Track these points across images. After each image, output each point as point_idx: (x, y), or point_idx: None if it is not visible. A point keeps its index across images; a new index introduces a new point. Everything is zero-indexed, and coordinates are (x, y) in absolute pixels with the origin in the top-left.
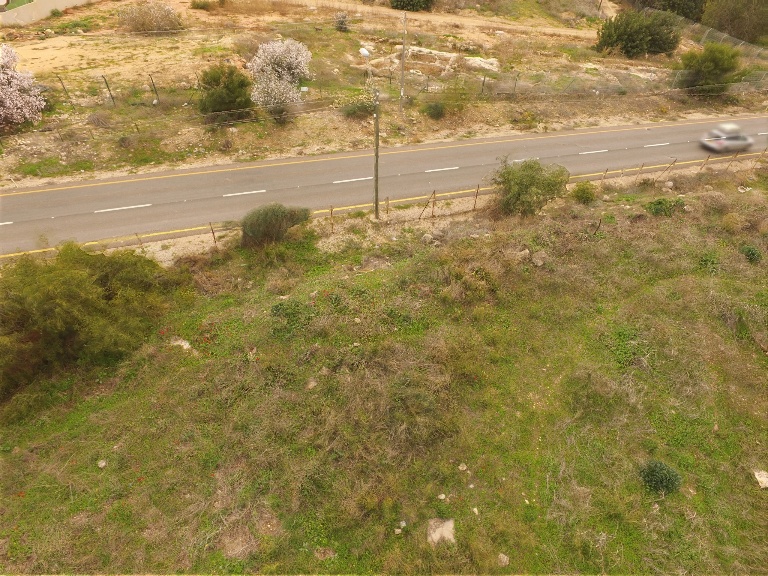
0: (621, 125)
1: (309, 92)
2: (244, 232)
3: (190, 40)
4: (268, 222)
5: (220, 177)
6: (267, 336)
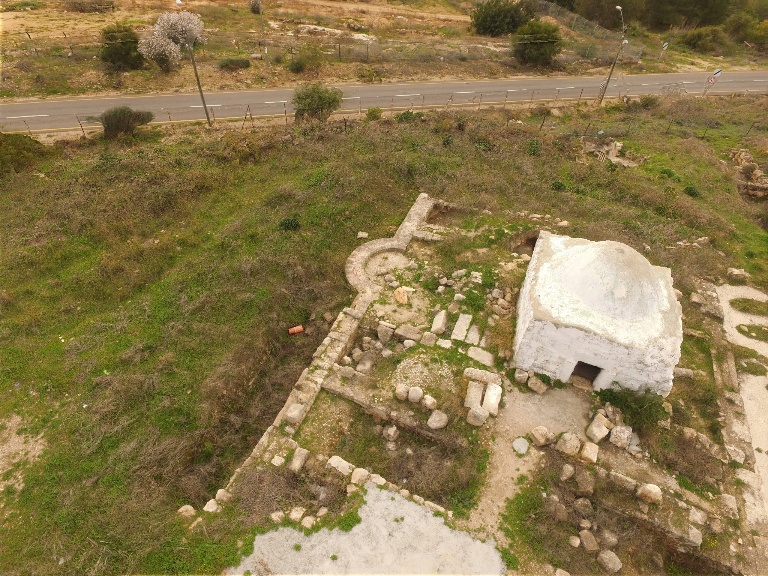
0: (447, 80)
1: (199, 52)
2: (105, 127)
3: (117, 16)
4: (118, 117)
5: (106, 102)
6: (92, 169)
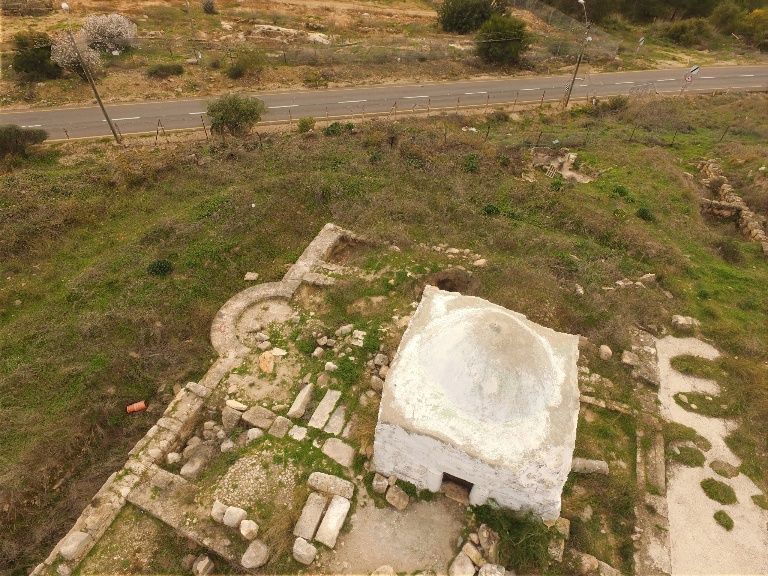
0: (401, 83)
1: (131, 58)
2: None
3: (52, 19)
4: (3, 137)
5: (9, 117)
6: None
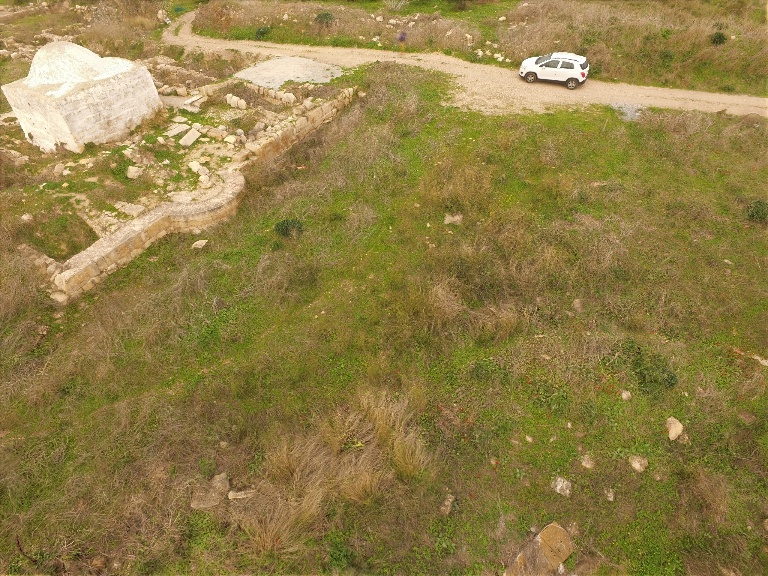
0: None
1: None
2: None
3: None
4: None
5: None
6: None
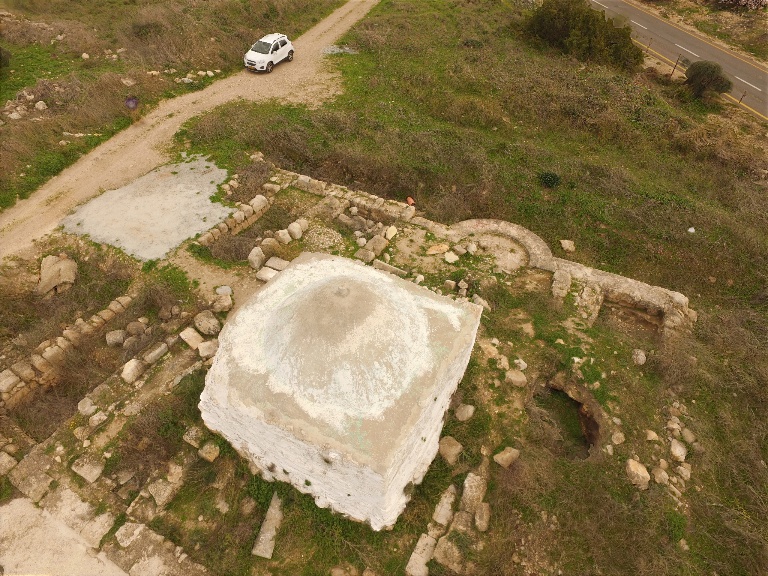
0: None
1: None
2: None
3: None
4: (700, 71)
5: (760, 74)
6: None
